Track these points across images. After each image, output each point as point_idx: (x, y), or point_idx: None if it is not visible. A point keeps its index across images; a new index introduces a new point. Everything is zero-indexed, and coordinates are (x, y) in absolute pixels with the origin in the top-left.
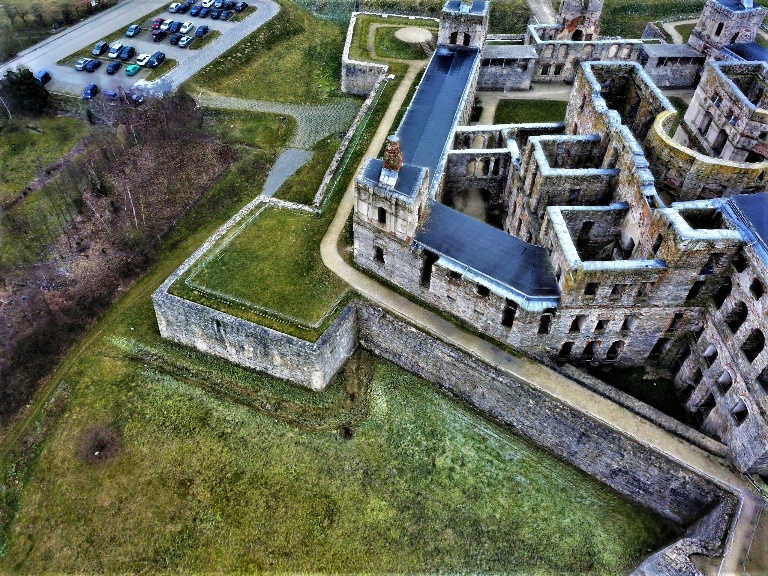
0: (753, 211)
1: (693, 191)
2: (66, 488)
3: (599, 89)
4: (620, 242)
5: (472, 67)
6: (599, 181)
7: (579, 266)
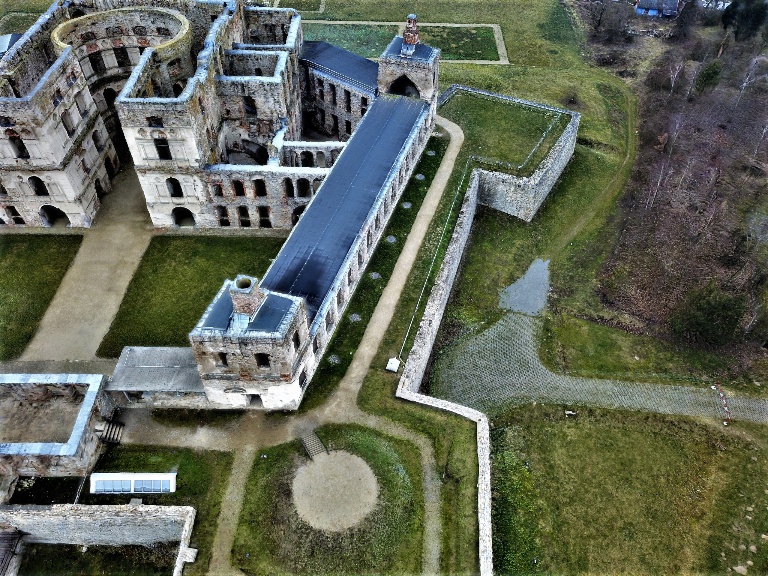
0: None
1: None
2: (579, 93)
3: None
4: None
5: (272, 267)
6: None
7: None
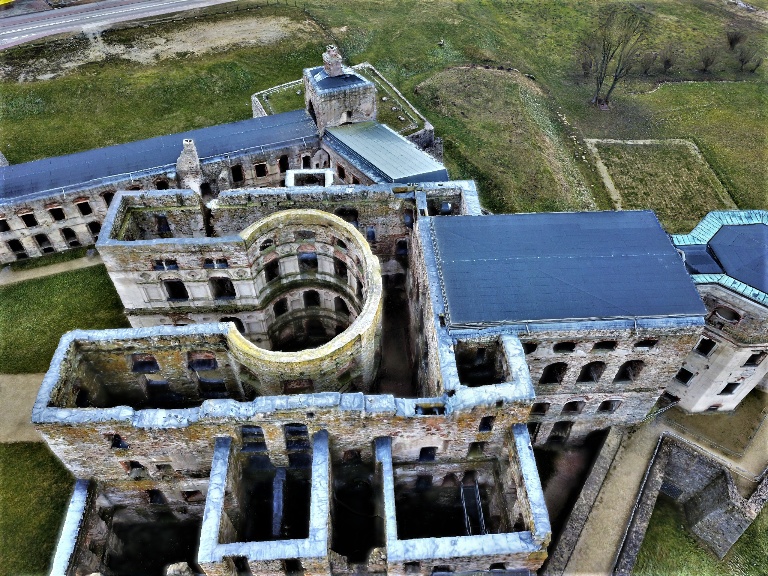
0: (481, 312)
1: (370, 353)
2: None
3: (130, 410)
4: (401, 461)
5: None
6: (329, 464)
7: (544, 538)
